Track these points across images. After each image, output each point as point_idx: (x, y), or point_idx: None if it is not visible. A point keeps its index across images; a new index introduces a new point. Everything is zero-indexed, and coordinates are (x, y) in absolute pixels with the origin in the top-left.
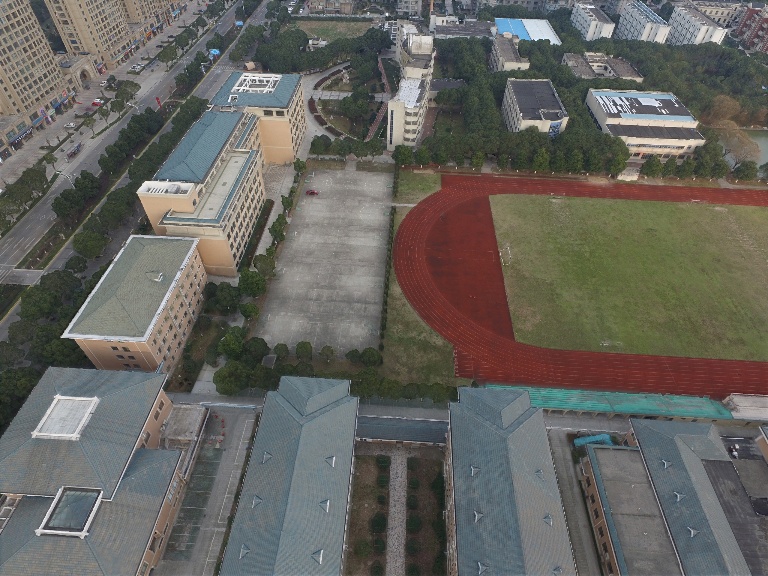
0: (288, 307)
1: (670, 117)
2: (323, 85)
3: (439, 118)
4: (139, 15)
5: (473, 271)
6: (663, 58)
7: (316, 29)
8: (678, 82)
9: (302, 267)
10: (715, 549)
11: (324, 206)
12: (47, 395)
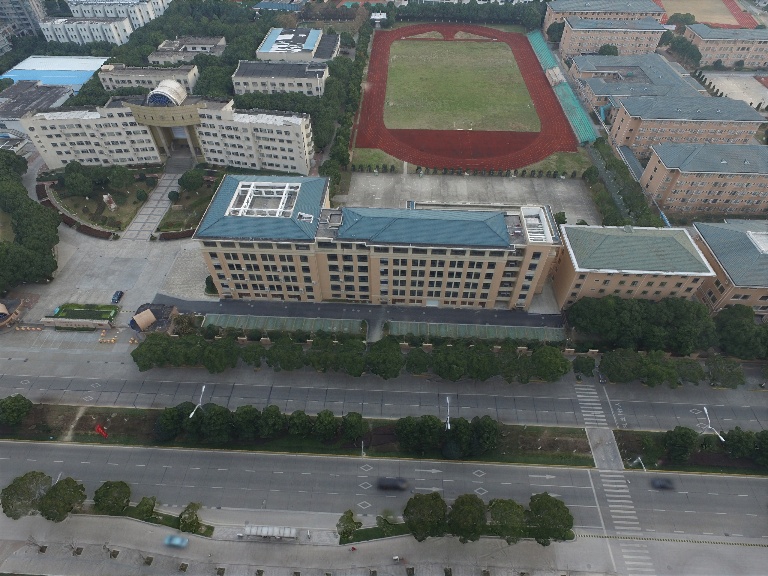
0: None
1: (312, 35)
2: None
3: None
4: None
5: (483, 141)
6: None
7: None
8: None
9: None
10: (651, 85)
11: None
12: (762, 265)
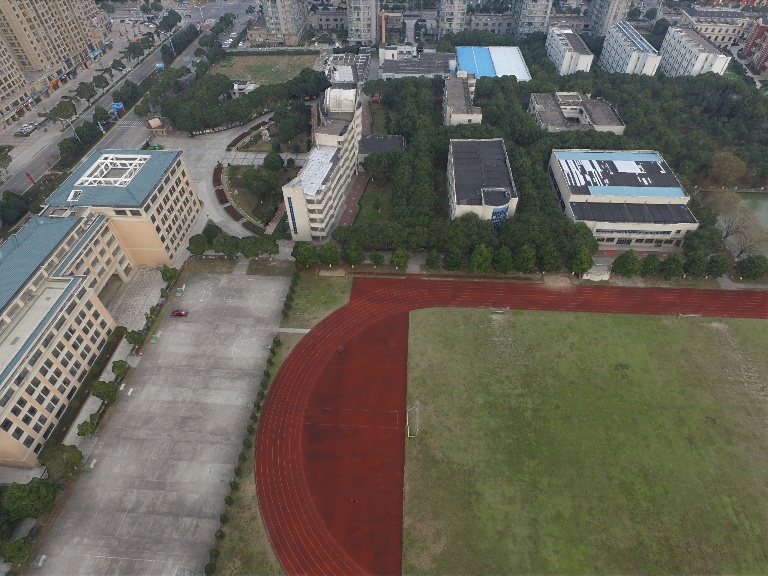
0: (87, 527)
1: (653, 190)
2: (239, 144)
3: (369, 188)
4: (43, 61)
5: (364, 450)
6: (653, 94)
7: (252, 67)
8: (668, 132)
9: (129, 447)
10: None
11: (189, 335)
12: None
